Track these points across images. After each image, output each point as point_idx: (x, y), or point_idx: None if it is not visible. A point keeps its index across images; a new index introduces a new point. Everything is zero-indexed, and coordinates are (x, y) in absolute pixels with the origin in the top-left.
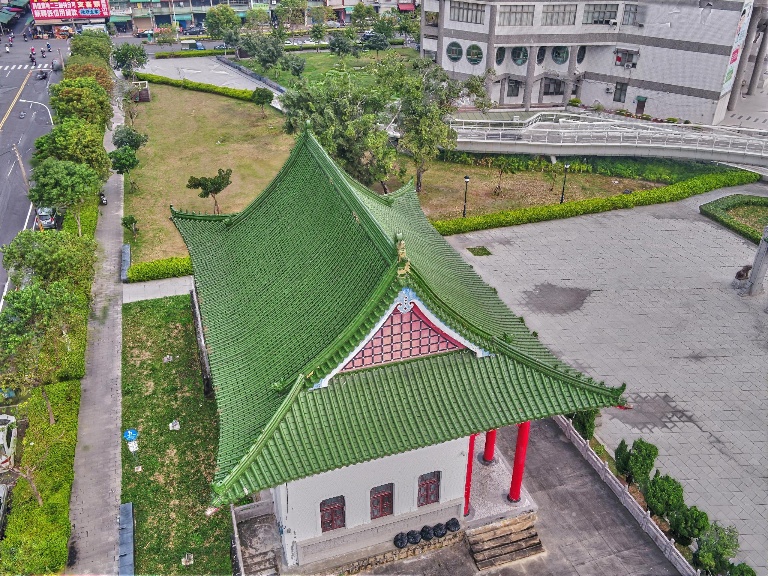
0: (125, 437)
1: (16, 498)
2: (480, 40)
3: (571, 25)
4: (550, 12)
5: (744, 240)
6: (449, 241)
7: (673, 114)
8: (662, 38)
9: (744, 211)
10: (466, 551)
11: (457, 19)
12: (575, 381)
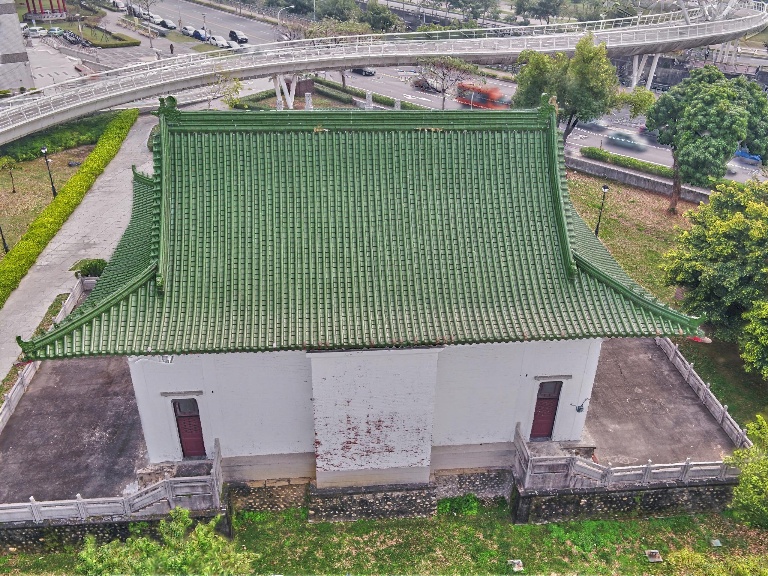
0: None
1: None
2: None
3: None
4: None
5: None
6: (39, 278)
7: None
8: None
9: None
10: None
11: None
12: None
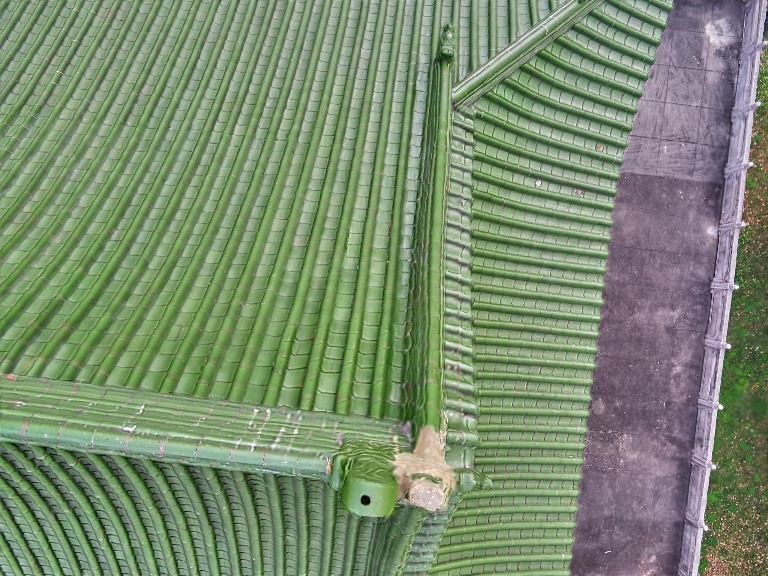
0: None
1: None
2: None
3: None
4: None
5: None
6: None
7: None
8: None
9: None
10: None
11: None
12: None
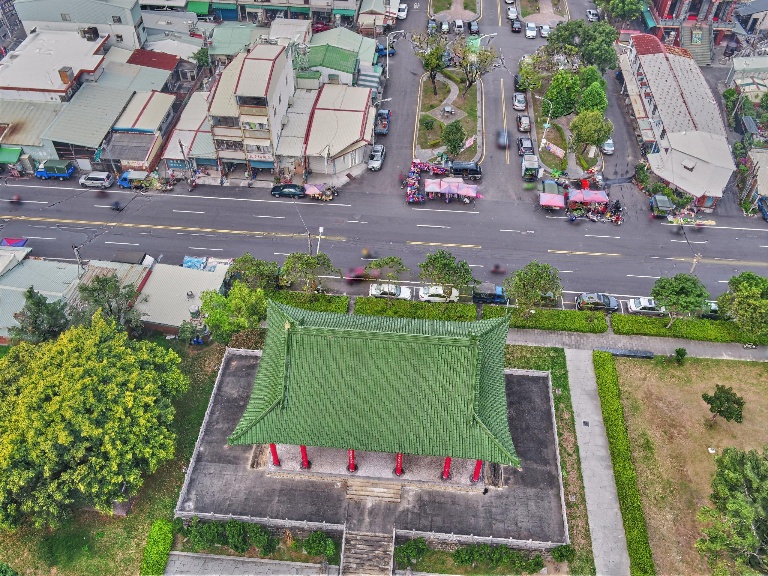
0: None
1: (396, 300)
2: None
3: None
4: None
5: None
6: None
7: None
8: None
9: None
10: None
11: None
12: None
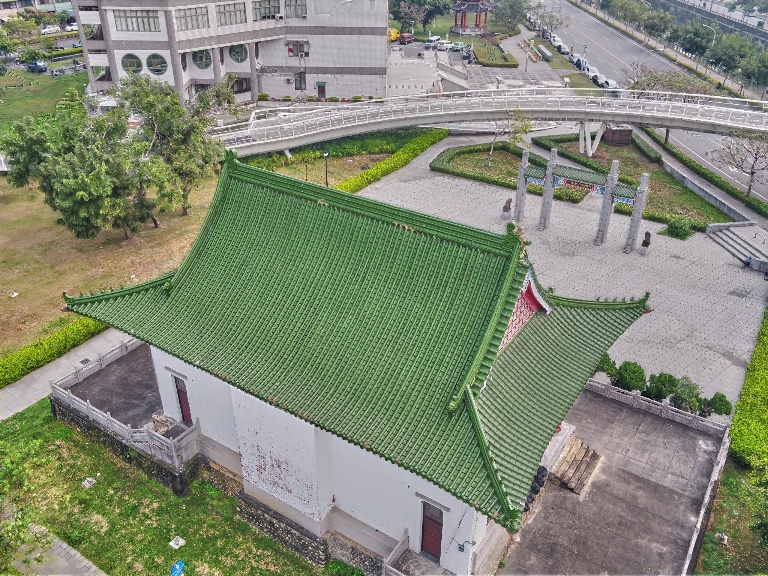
0: (173, 575)
1: None
2: (160, 48)
3: (244, 23)
4: (222, 12)
5: (477, 182)
6: None
7: (352, 93)
8: (326, 26)
9: (460, 160)
10: (558, 487)
11: (126, 29)
12: (613, 305)
